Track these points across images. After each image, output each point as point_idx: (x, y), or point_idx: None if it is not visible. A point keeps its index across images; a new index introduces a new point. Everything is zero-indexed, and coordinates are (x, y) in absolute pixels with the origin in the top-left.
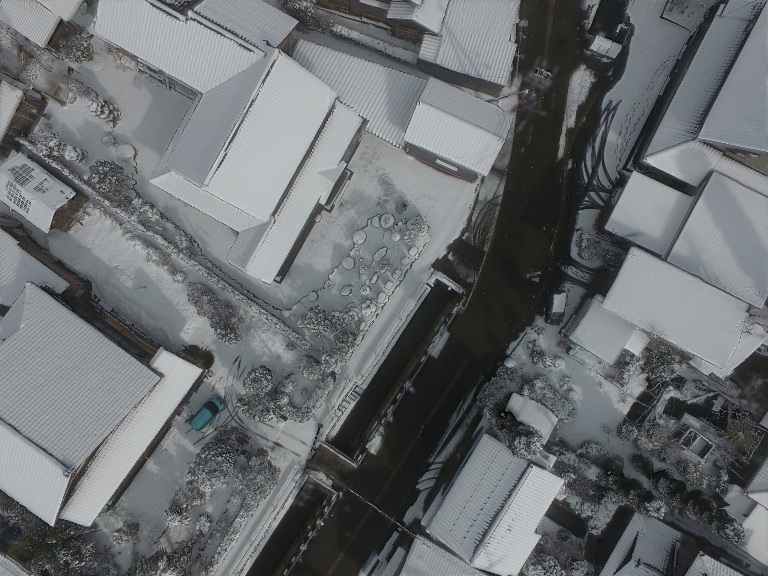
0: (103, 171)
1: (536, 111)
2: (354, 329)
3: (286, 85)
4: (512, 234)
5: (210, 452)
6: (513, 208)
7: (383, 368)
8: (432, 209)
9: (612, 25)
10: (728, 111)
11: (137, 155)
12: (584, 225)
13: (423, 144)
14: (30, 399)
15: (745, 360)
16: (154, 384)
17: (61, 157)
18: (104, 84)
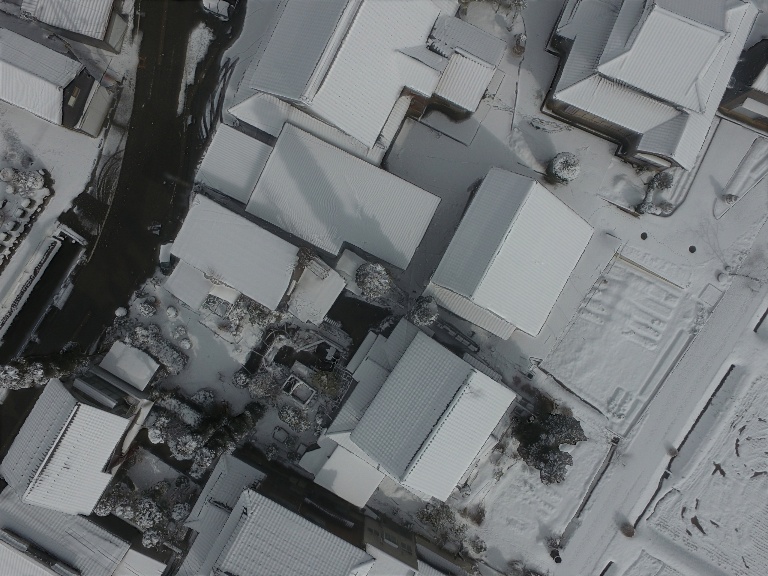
0: None
1: (156, 68)
2: None
3: None
4: (133, 188)
5: None
6: (135, 163)
7: (21, 321)
8: (57, 164)
9: None
10: (270, 60)
11: None
12: None
13: None
14: None
15: (331, 307)
16: None
17: None
18: None
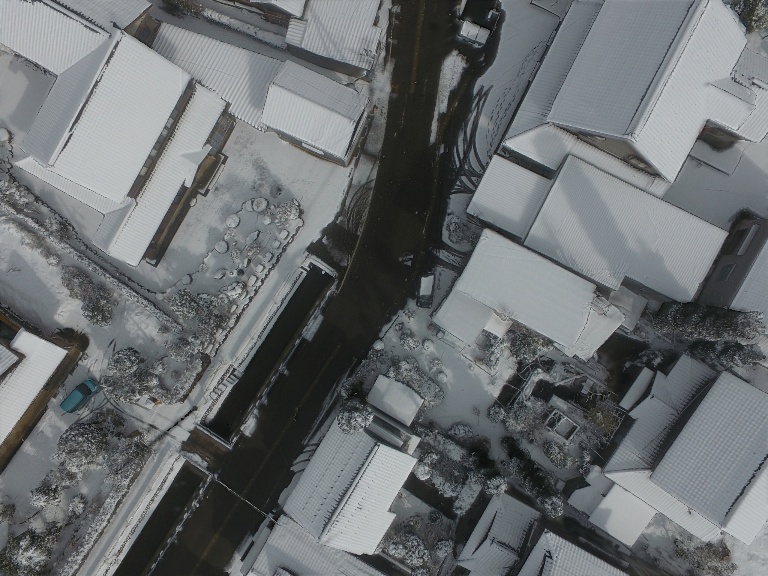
0: None
1: (408, 96)
2: (226, 312)
3: (133, 66)
4: (385, 218)
5: (71, 432)
6: (386, 192)
7: (262, 351)
8: (306, 193)
9: (486, 11)
10: (573, 94)
11: (12, 139)
12: (455, 209)
13: (280, 127)
14: None
15: (605, 342)
16: (11, 364)
17: None
18: None
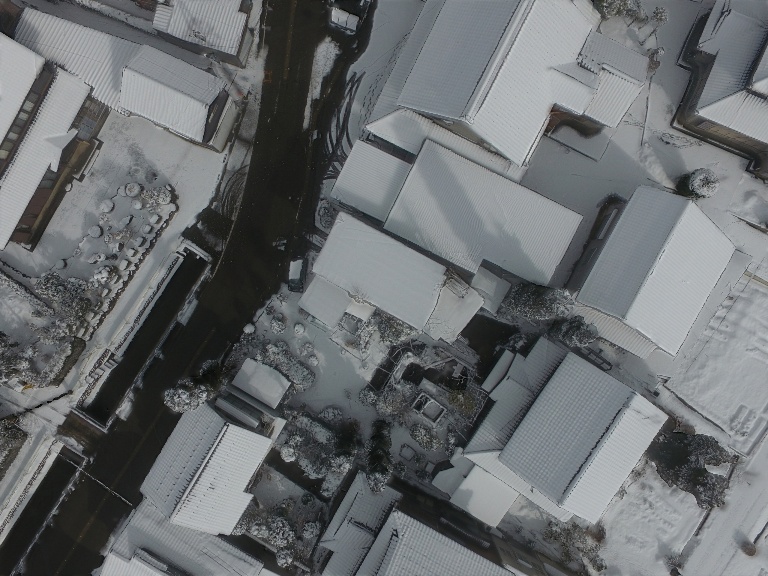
0: None
1: (282, 82)
2: None
3: None
4: (258, 203)
5: None
6: (260, 178)
7: (141, 336)
8: (181, 179)
9: None
10: (420, 78)
11: None
12: (328, 195)
13: (137, 110)
14: None
15: (467, 325)
16: None
17: None
18: None
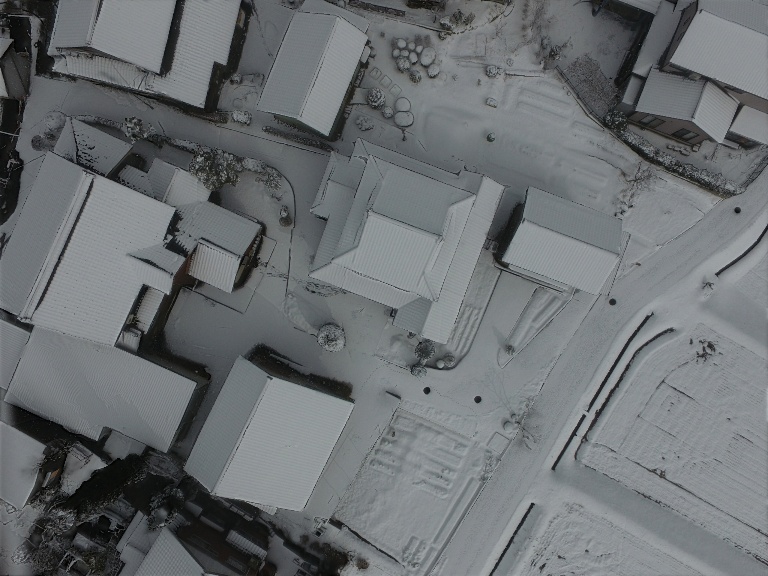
0: None
1: None
2: None
3: None
4: None
5: None
6: None
7: None
8: None
9: None
10: (5, 266)
11: None
12: None
13: None
14: None
15: None
16: None
17: None
18: None
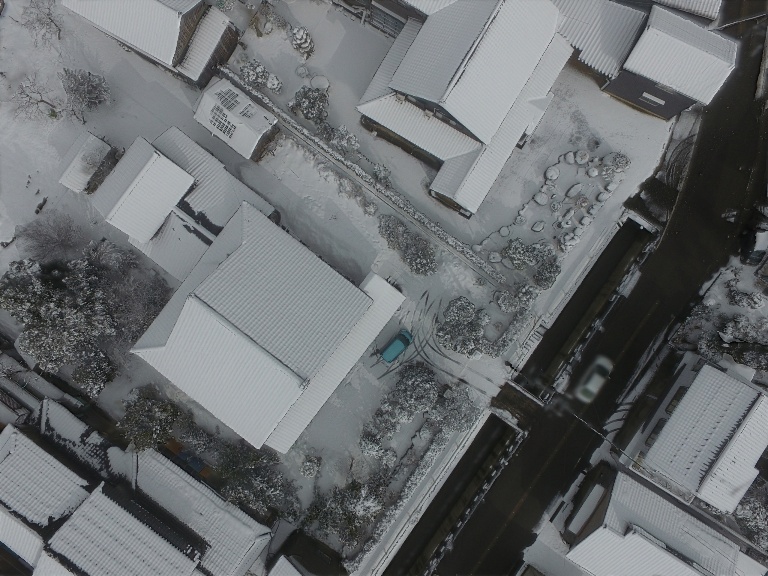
0: (313, 96)
1: None
2: None
3: (523, 4)
4: (707, 174)
5: (417, 379)
6: (708, 148)
7: (566, 309)
8: (625, 147)
9: None
10: None
11: (329, 87)
12: None
13: (644, 72)
14: (261, 312)
15: None
16: (369, 306)
17: (261, 85)
18: (297, 17)
